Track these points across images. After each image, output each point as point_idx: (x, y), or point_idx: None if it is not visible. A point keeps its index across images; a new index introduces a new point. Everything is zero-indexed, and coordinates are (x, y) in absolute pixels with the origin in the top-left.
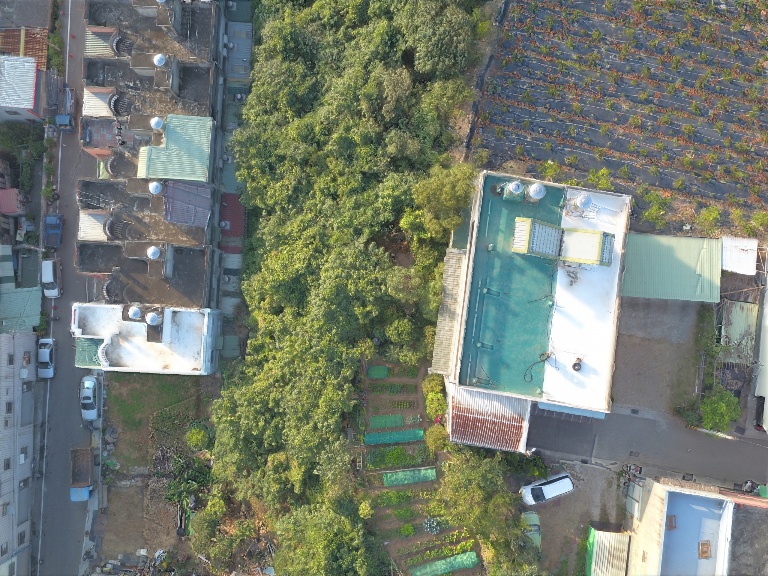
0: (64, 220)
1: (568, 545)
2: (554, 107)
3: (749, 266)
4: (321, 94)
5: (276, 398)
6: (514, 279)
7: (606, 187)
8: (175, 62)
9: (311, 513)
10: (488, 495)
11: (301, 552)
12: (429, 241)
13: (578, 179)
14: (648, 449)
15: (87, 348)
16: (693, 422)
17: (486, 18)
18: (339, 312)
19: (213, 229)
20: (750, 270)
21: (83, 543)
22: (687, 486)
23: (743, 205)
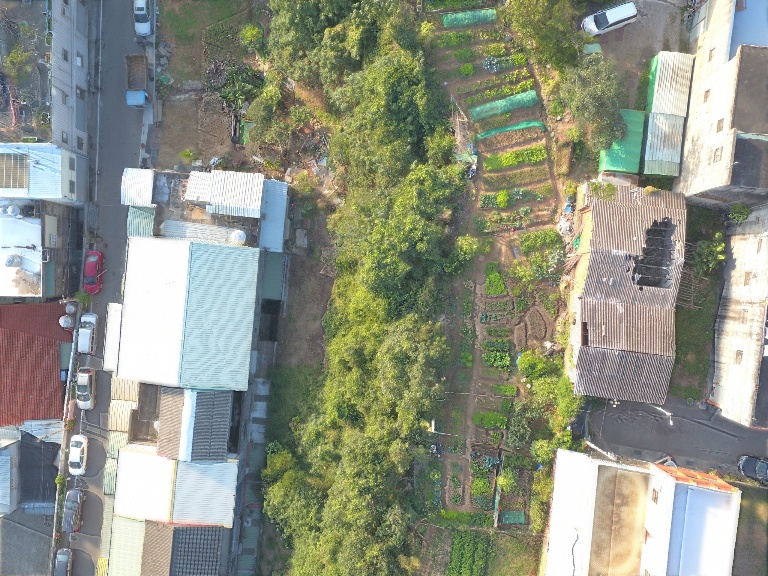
0: None
1: (630, 80)
2: None
3: None
4: None
5: None
6: None
7: None
8: None
9: None
10: (552, 4)
11: (359, 108)
12: None
13: None
14: None
15: None
16: None
17: None
18: None
19: None
20: None
21: (139, 155)
22: None
23: None
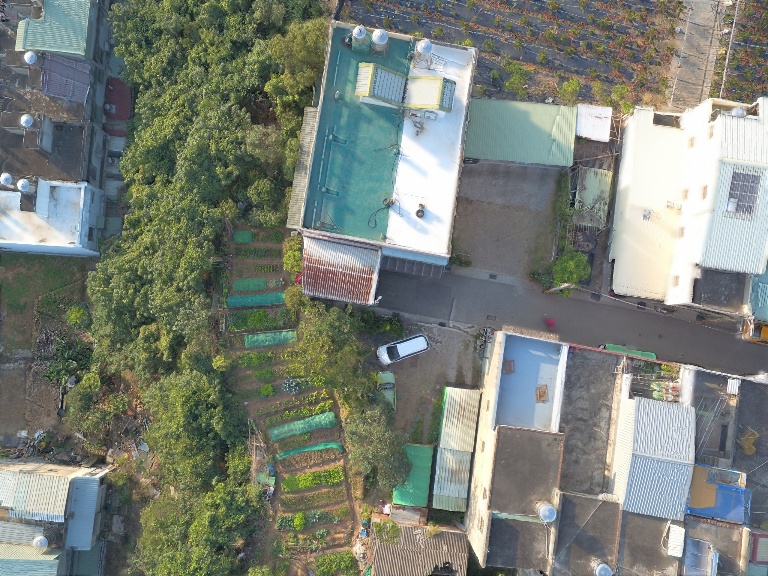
0: None
1: (424, 405)
2: None
3: (603, 133)
4: None
5: (144, 264)
6: (361, 128)
7: None
8: None
9: (176, 377)
10: (339, 347)
11: (166, 416)
12: (294, 107)
13: None
14: (505, 313)
15: None
16: (546, 284)
17: None
18: (201, 172)
19: (93, 106)
20: (604, 137)
21: None
22: (528, 333)
23: (604, 81)
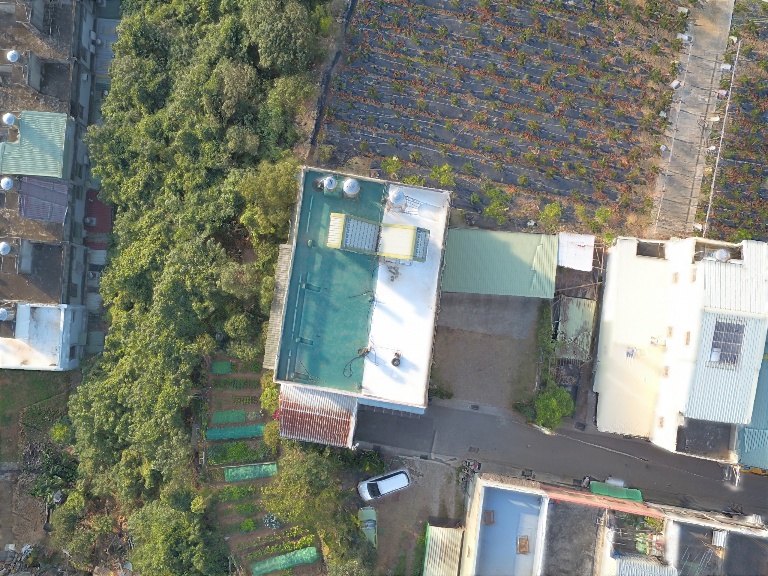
0: None
1: (406, 540)
2: (400, 103)
3: (585, 262)
4: (172, 90)
5: (124, 393)
6: (335, 275)
7: (447, 183)
8: (33, 58)
9: (157, 508)
10: (317, 490)
11: (148, 547)
12: (271, 237)
13: (423, 175)
14: (487, 445)
15: None
16: (529, 418)
17: (334, 14)
18: (177, 308)
19: (72, 225)
20: (586, 266)
21: None
22: (508, 481)
23: (588, 201)
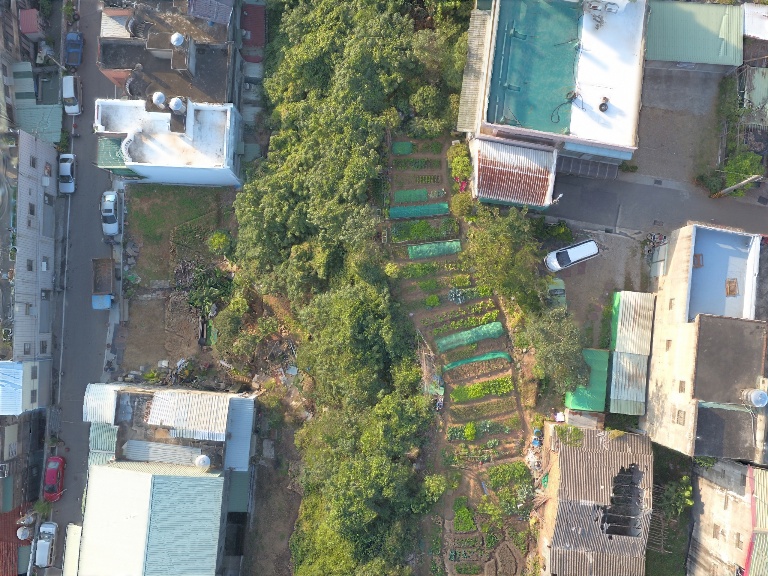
0: (84, 39)
1: (593, 313)
2: None
3: None
4: None
5: (300, 180)
6: (540, 23)
7: None
8: None
9: (336, 292)
10: (515, 250)
11: (326, 332)
12: (452, 16)
13: None
14: (672, 218)
15: (110, 146)
16: (717, 186)
17: None
18: (364, 80)
19: (235, 29)
20: None
21: (104, 356)
22: None
23: None
